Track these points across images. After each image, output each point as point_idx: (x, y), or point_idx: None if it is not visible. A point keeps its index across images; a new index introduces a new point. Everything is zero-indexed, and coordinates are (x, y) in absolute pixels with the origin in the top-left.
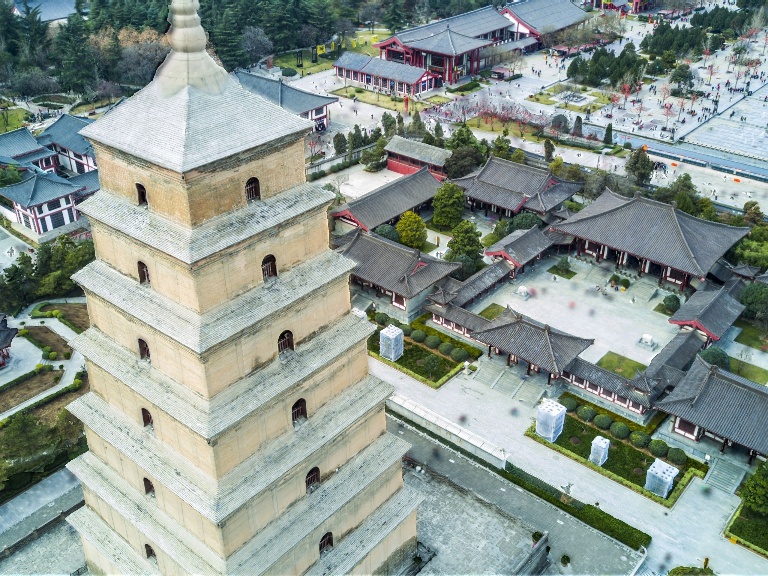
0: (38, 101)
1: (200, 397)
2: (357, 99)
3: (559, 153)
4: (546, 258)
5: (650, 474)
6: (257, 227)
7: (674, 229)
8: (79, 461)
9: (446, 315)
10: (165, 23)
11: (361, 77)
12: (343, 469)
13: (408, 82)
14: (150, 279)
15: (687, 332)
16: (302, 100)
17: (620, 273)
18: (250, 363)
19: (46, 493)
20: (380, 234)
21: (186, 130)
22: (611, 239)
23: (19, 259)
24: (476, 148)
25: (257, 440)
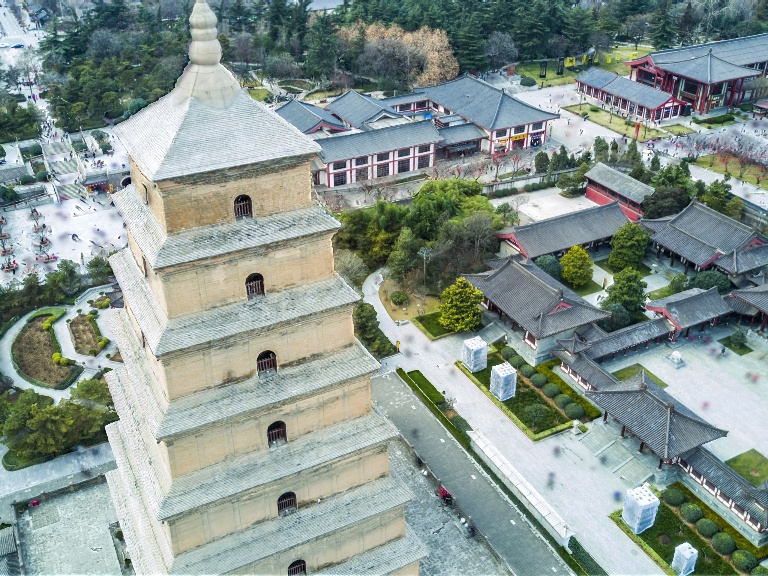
0: (283, 84)
1: (164, 397)
2: (588, 118)
3: None
4: (723, 326)
5: None
6: (238, 244)
7: None
8: (114, 425)
9: (573, 365)
10: (413, 22)
11: (601, 95)
12: (327, 501)
13: (648, 106)
14: None
15: None
16: (521, 112)
17: None
18: (221, 375)
19: None
20: (539, 264)
21: (173, 140)
22: None
23: None
24: (683, 189)
25: (222, 451)
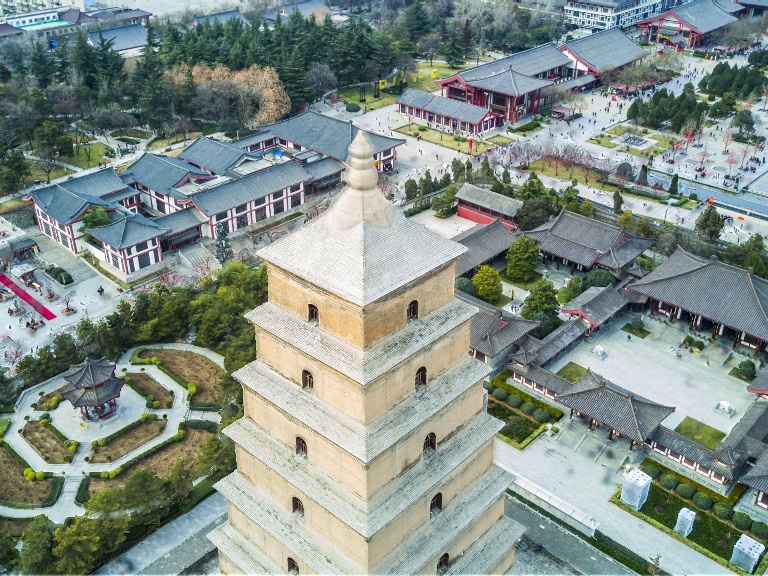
0: (116, 135)
1: (358, 497)
2: (421, 138)
3: (627, 205)
4: (619, 315)
5: (737, 549)
6: (417, 346)
7: (750, 295)
8: (220, 533)
9: (527, 375)
10: (237, 60)
11: (424, 114)
12: (467, 553)
13: (471, 122)
14: (314, 387)
15: (765, 401)
16: (371, 142)
17: (694, 335)
18: (401, 465)
19: (161, 544)
20: (458, 287)
21: (364, 264)
22: (687, 302)
23: (120, 306)
24: (547, 199)
25: (402, 533)
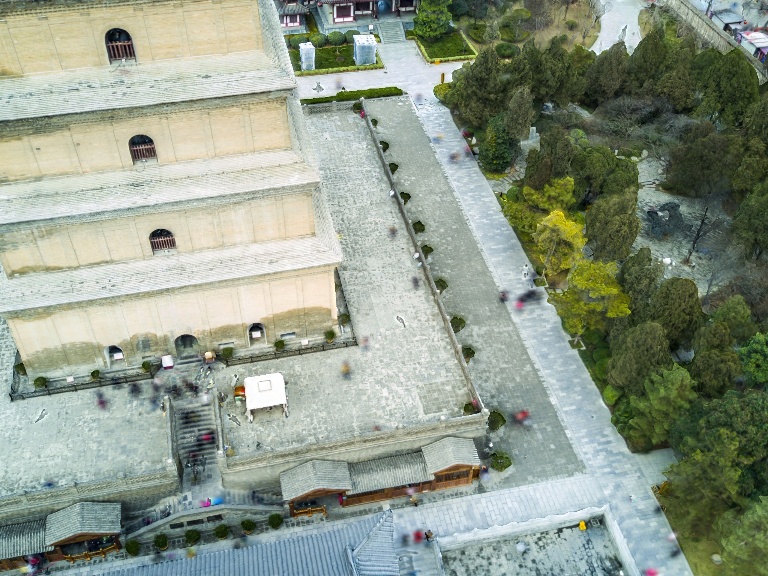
0: None
1: None
2: None
3: None
4: None
5: (360, 47)
6: None
7: None
8: None
9: None
10: None
11: None
12: None
13: None
14: None
15: None
16: None
17: None
18: None
19: None
20: None
21: None
22: None
23: None
24: None
25: None
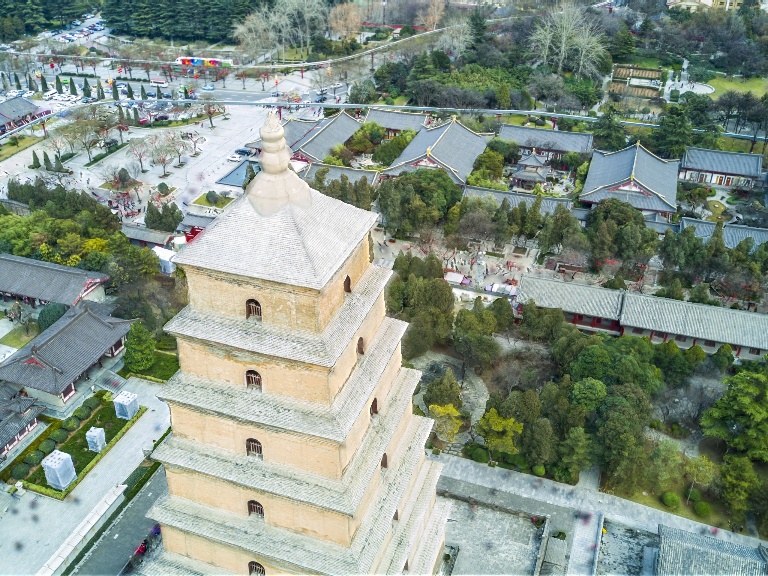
0: None
1: None
2: None
3: None
4: None
5: None
6: None
7: None
8: None
9: None
10: None
11: None
12: None
13: None
14: None
15: None
16: None
17: None
18: None
19: None
20: None
21: None
22: None
23: None
24: None
25: None
